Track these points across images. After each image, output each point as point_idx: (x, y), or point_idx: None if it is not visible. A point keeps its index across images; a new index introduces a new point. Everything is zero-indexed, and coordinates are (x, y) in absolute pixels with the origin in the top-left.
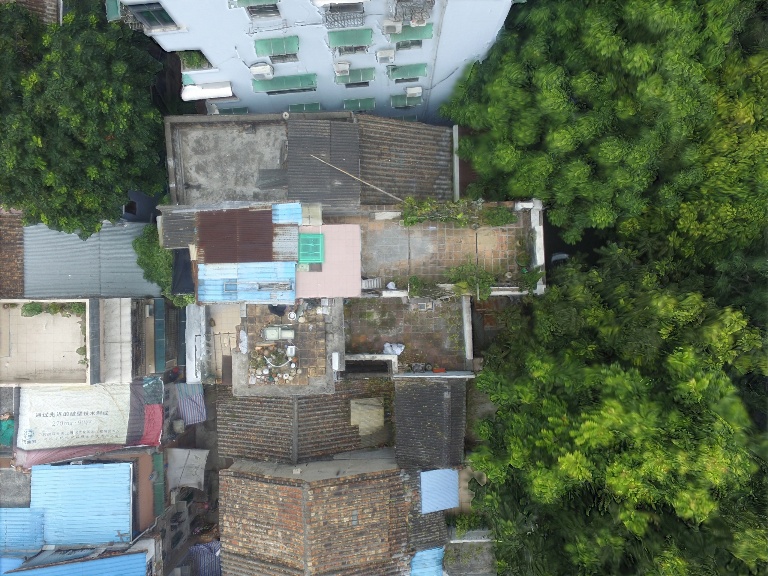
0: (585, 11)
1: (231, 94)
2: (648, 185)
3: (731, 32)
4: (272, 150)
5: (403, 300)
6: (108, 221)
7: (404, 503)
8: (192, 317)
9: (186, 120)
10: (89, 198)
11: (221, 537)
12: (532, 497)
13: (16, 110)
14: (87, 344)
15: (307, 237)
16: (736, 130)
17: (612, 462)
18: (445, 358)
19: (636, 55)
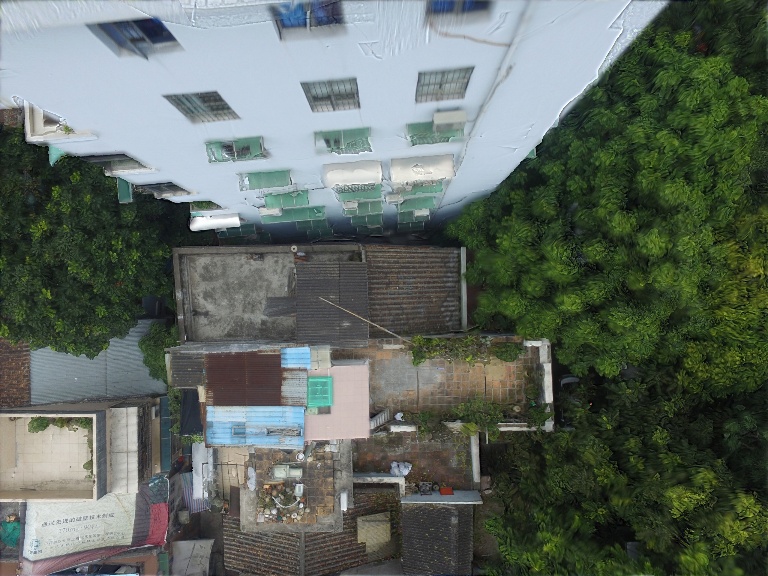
0: (595, 171)
1: (239, 225)
2: None
3: (741, 190)
4: (280, 277)
5: None
6: None
7: None
8: None
9: (194, 251)
10: (97, 327)
11: None
12: None
13: (25, 249)
14: (94, 459)
15: (316, 380)
16: (746, 283)
17: None
18: (452, 477)
19: (647, 236)
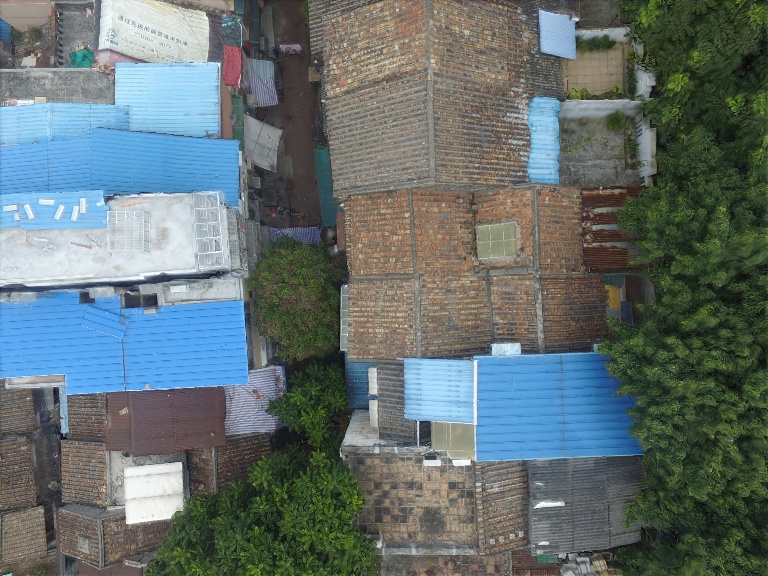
0: None
1: None
2: None
3: None
4: None
5: None
6: None
7: (522, 41)
8: None
9: None
10: None
11: (327, 84)
12: None
13: None
14: None
15: None
16: None
17: None
18: None
19: None
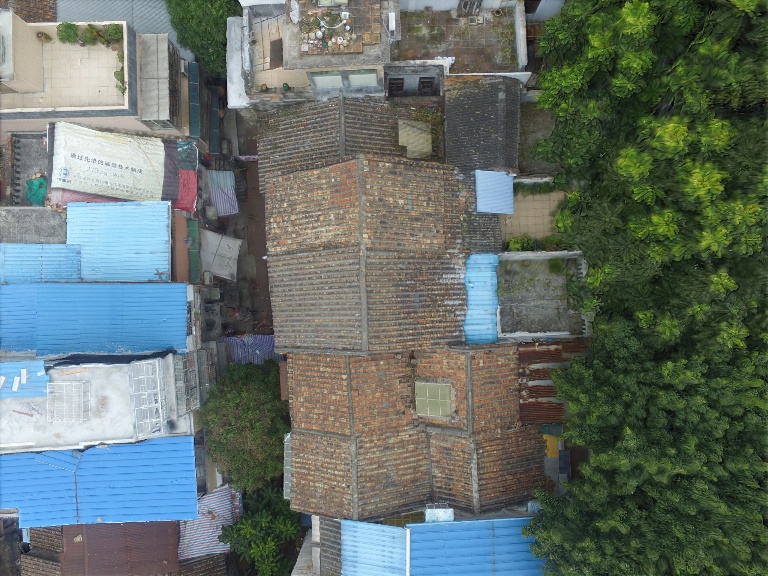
0: None
1: None
2: None
3: None
4: None
5: (453, 14)
6: None
7: (458, 201)
8: (233, 40)
9: None
10: None
11: (268, 241)
12: None
13: None
14: (125, 66)
15: None
16: None
17: None
18: None
19: None
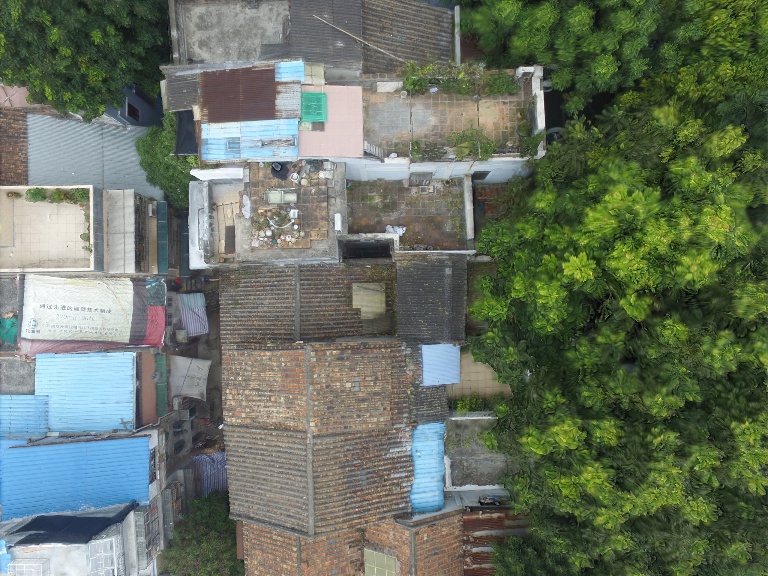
0: None
1: None
2: (648, 52)
3: None
4: (275, 25)
5: (405, 184)
6: (111, 120)
7: (406, 375)
8: (195, 203)
9: None
10: (93, 71)
11: (224, 411)
12: (533, 341)
13: None
14: (91, 229)
15: (310, 96)
16: None
17: (612, 248)
18: (446, 241)
19: None
